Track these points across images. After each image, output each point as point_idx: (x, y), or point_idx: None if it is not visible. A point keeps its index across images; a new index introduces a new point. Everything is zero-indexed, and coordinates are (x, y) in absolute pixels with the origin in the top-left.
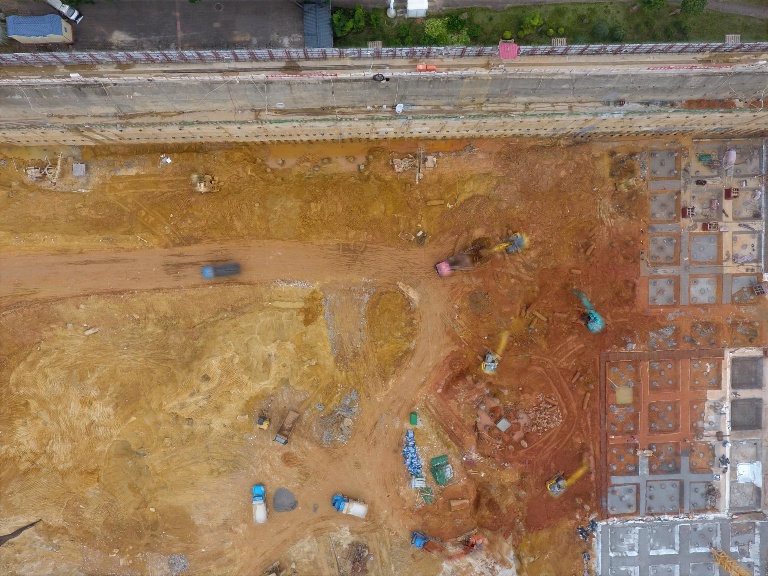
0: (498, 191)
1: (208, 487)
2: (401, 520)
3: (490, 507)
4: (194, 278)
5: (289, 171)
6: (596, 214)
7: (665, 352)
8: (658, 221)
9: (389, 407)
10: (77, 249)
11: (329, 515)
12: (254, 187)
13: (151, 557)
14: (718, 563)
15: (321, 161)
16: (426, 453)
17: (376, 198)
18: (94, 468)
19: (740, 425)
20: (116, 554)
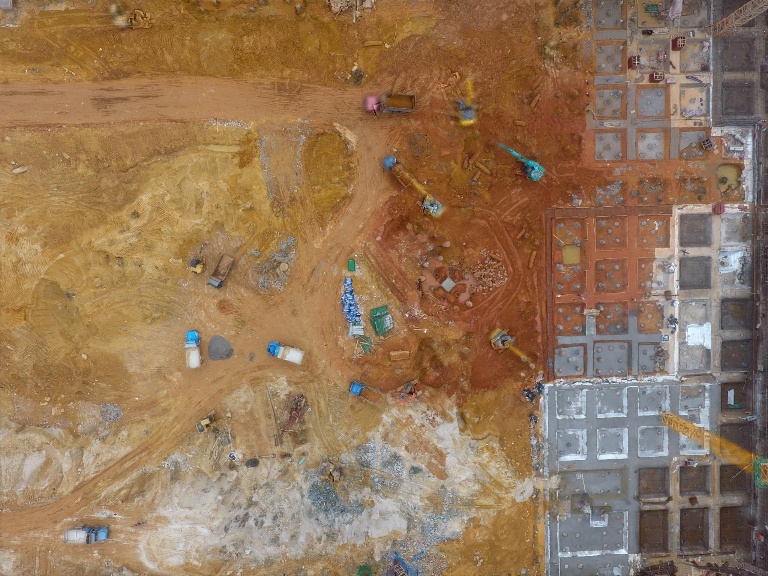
0: (437, 30)
1: (141, 334)
2: (339, 370)
3: (433, 365)
4: (124, 113)
5: (224, 12)
6: (540, 64)
7: (612, 208)
8: (604, 73)
9: (327, 254)
10: (2, 78)
11: (266, 364)
12: (187, 24)
13: (83, 406)
14: (667, 426)
15: (257, 2)
16: (365, 303)
17: (310, 32)
18: (21, 305)
19: (689, 285)
20: (47, 403)
